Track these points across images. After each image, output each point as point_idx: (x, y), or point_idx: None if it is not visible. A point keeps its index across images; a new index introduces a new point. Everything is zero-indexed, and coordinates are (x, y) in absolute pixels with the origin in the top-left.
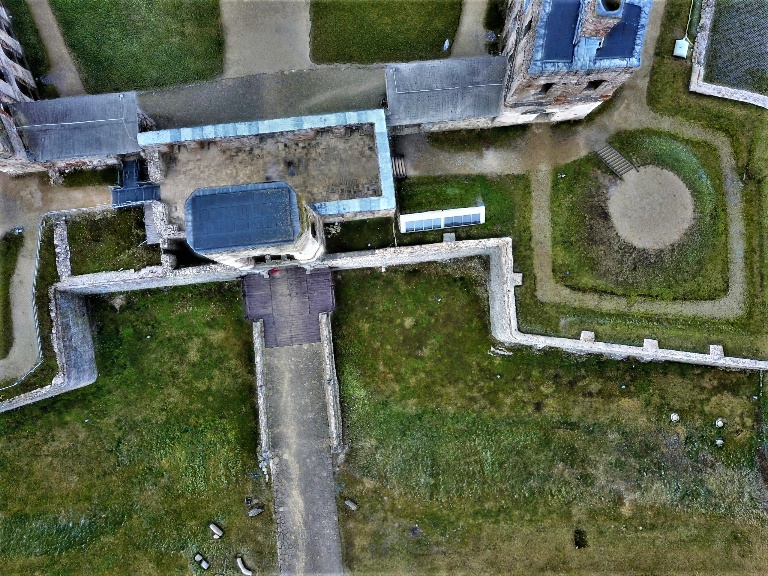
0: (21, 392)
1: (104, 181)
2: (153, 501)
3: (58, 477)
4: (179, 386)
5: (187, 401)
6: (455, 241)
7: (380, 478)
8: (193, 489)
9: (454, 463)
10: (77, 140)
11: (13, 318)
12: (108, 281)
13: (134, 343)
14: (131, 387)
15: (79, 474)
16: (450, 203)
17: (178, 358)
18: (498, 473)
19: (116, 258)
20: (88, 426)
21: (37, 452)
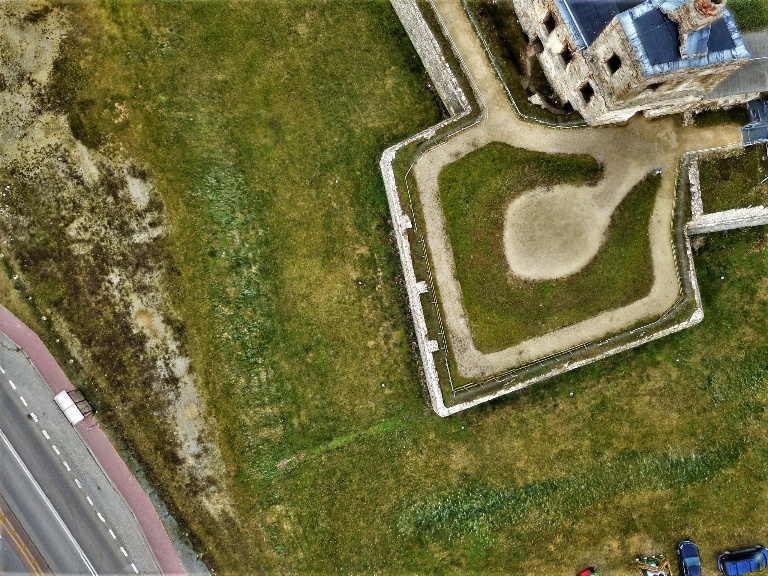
0: (660, 329)
1: (732, 121)
2: (763, 434)
3: (659, 415)
4: (752, 325)
5: (763, 339)
6: None
7: None
8: None
9: None
10: (742, 78)
11: (653, 257)
12: (737, 218)
13: (708, 285)
14: (708, 327)
15: (679, 412)
16: None
17: (748, 298)
18: None
19: (744, 196)
20: (678, 366)
21: (635, 392)
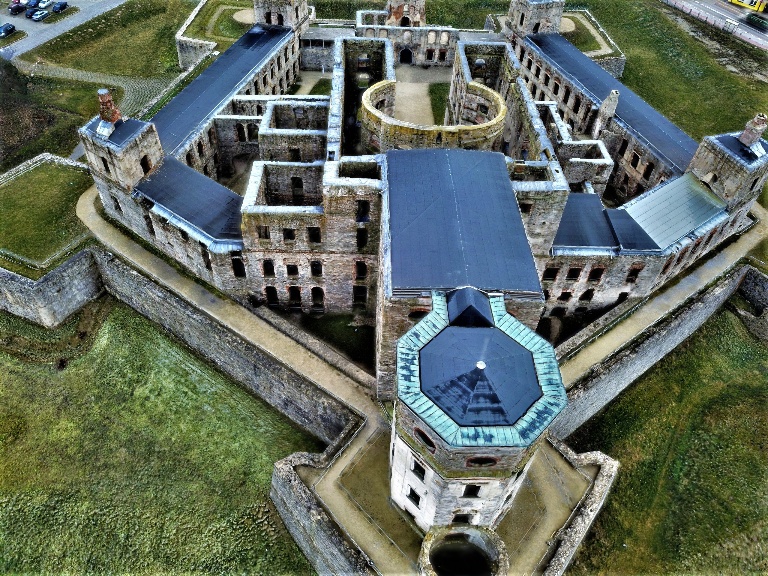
0: None
1: None
2: (456, 7)
3: None
4: None
5: None
6: (333, 20)
7: (371, 3)
8: (442, 8)
9: (342, 8)
10: None
11: None
12: None
13: None
14: None
15: None
16: (333, 27)
17: None
18: (326, 2)
19: None
20: None
21: None
